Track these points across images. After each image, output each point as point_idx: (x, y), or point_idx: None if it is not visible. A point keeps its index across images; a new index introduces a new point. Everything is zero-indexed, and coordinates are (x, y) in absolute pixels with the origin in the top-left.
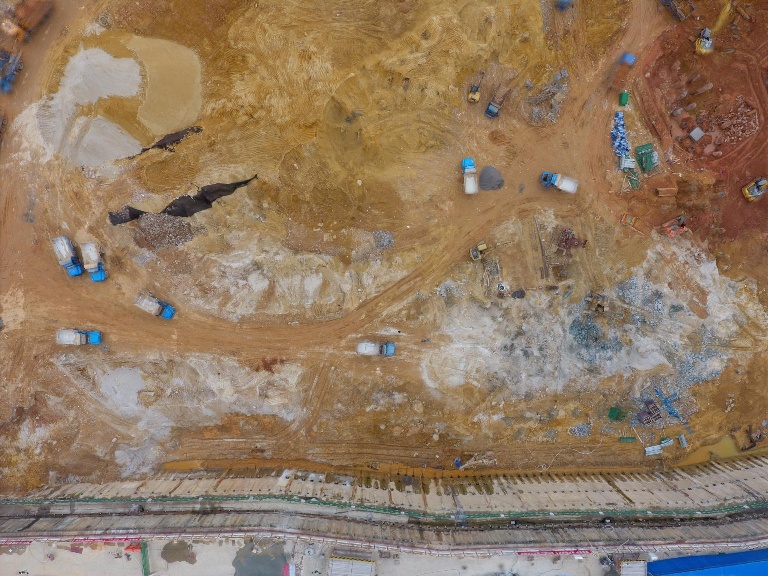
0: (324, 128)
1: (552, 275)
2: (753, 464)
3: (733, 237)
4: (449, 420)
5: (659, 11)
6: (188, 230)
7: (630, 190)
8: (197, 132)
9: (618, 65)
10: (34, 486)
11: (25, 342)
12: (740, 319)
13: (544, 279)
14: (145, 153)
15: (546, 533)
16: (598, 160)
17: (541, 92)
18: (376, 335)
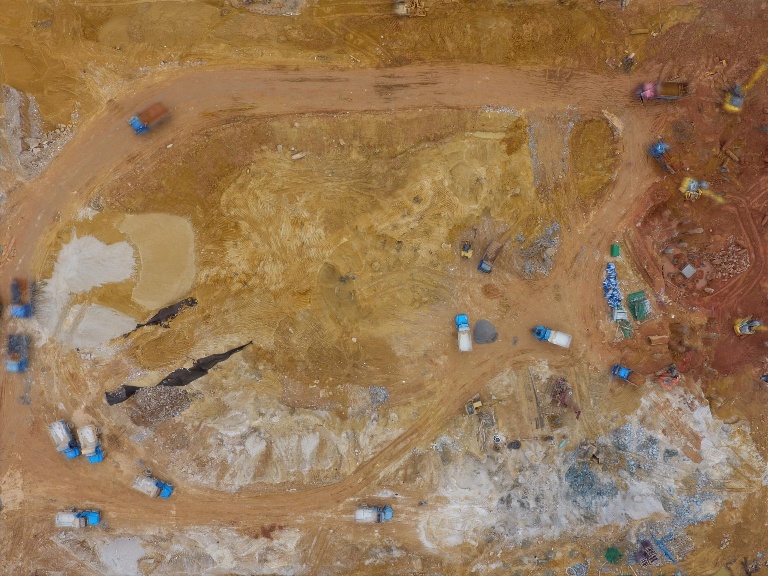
0: (318, 290)
1: (547, 424)
2: None
3: (726, 373)
4: (448, 573)
5: (649, 163)
6: (185, 398)
7: (623, 339)
8: (191, 306)
9: (609, 216)
10: None
11: (24, 522)
12: (734, 462)
13: (539, 429)
14: (140, 329)
15: None
16: (591, 310)
17: (533, 246)
18: (374, 498)
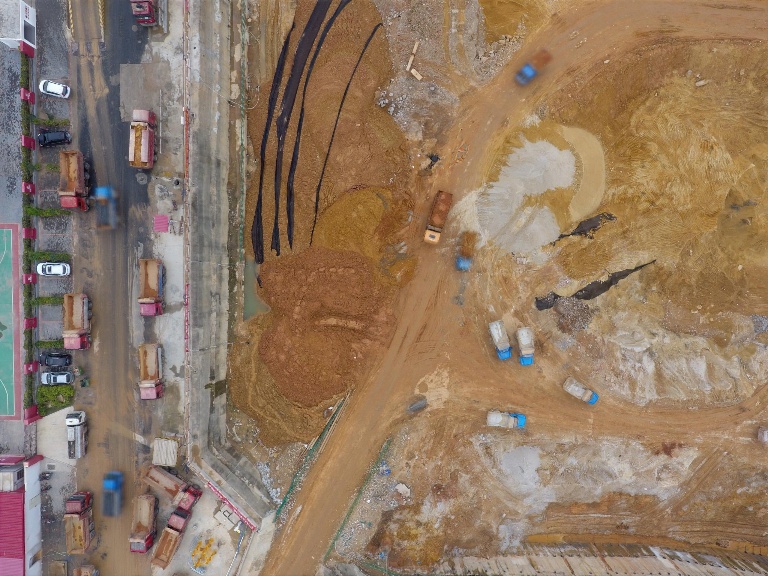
0: None
1: None
2: None
3: None
4: None
5: None
6: (587, 312)
7: None
8: (612, 219)
9: None
10: (434, 560)
11: (447, 421)
12: None
13: None
14: (565, 239)
15: None
16: None
17: None
18: None
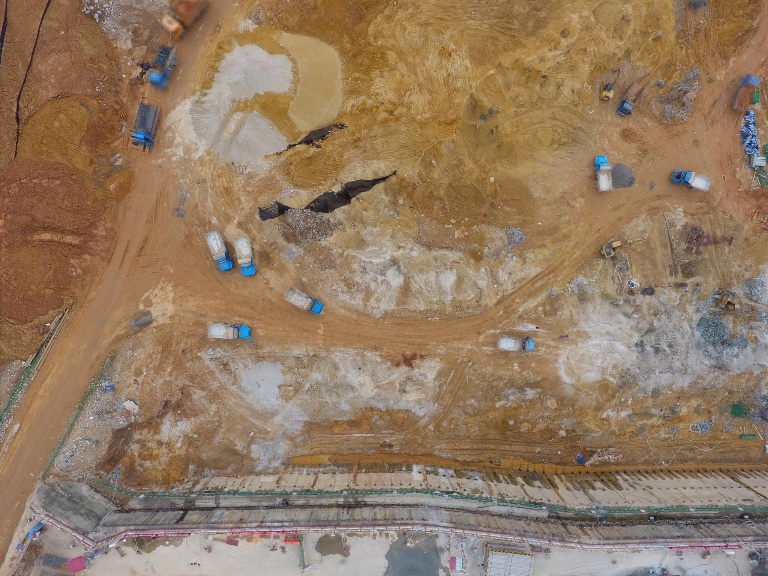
0: (460, 125)
1: (680, 272)
2: None
3: None
4: (580, 416)
5: None
6: (328, 226)
7: (759, 188)
8: (342, 128)
9: (749, 64)
10: (176, 479)
11: (174, 336)
12: None
13: (673, 276)
14: (292, 149)
15: (689, 528)
16: (728, 158)
17: (672, 90)
18: (514, 331)
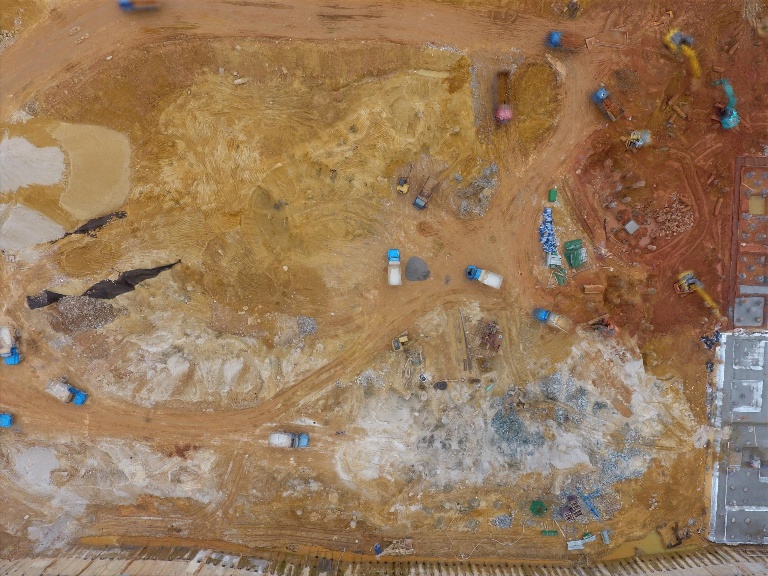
0: (251, 215)
1: (476, 367)
2: (675, 565)
3: (665, 332)
4: (364, 510)
5: (591, 110)
6: (110, 312)
7: (557, 286)
8: (121, 218)
9: (549, 161)
10: None
11: None
12: (665, 419)
13: (467, 371)
14: (67, 237)
15: None
16: (525, 255)
17: (470, 185)
18: (291, 425)
